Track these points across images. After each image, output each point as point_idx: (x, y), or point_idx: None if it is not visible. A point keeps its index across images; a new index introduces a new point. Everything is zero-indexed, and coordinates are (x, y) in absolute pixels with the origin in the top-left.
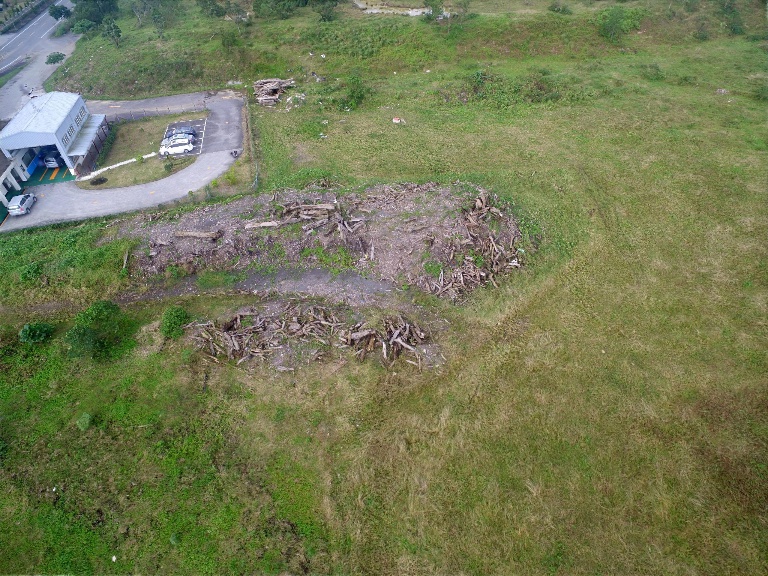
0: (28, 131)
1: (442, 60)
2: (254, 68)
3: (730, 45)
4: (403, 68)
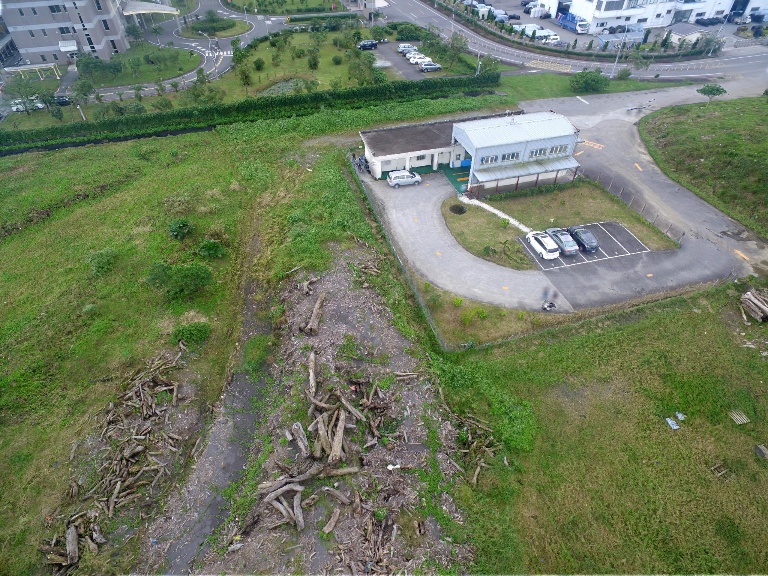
0: (467, 133)
1: None
2: None
3: None
4: None
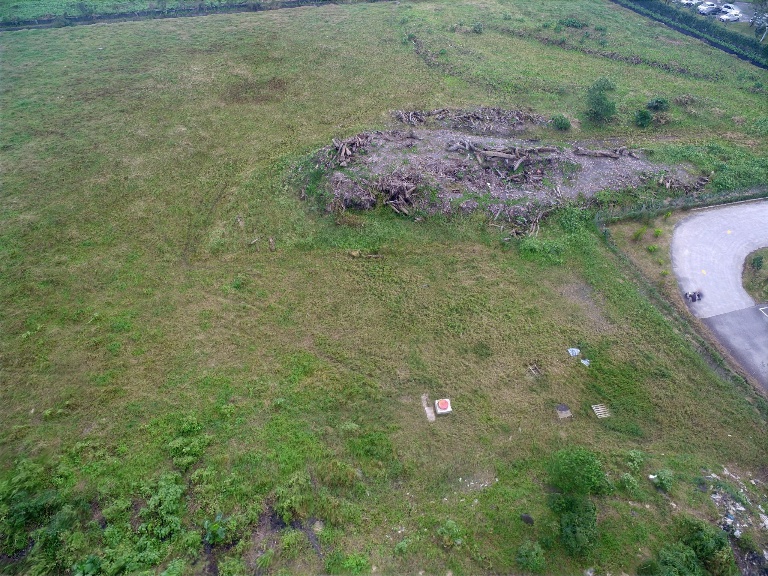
0: None
1: None
2: None
3: None
4: None
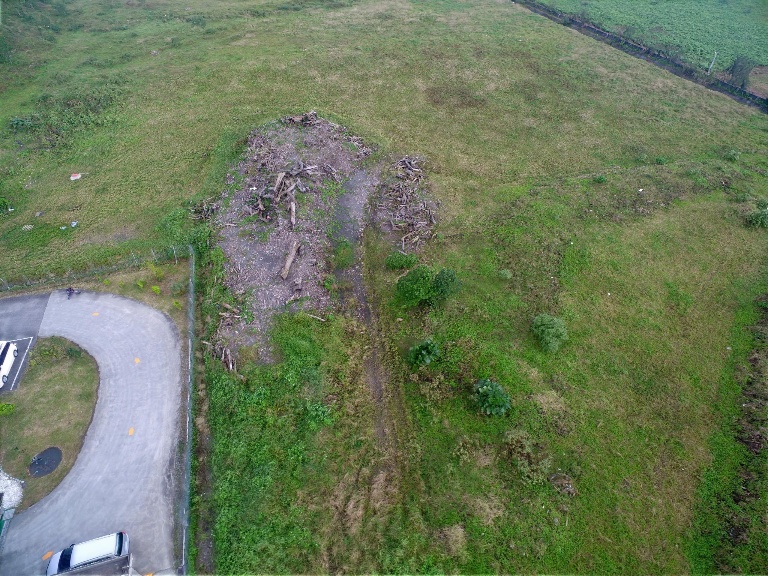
0: None
1: None
2: None
3: (75, 37)
4: None
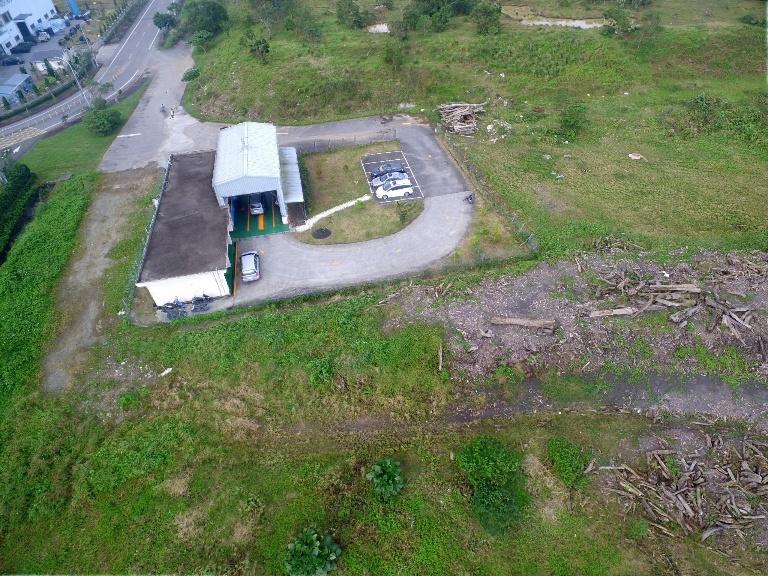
0: (252, 175)
1: (639, 80)
2: (427, 89)
3: None
4: (597, 90)
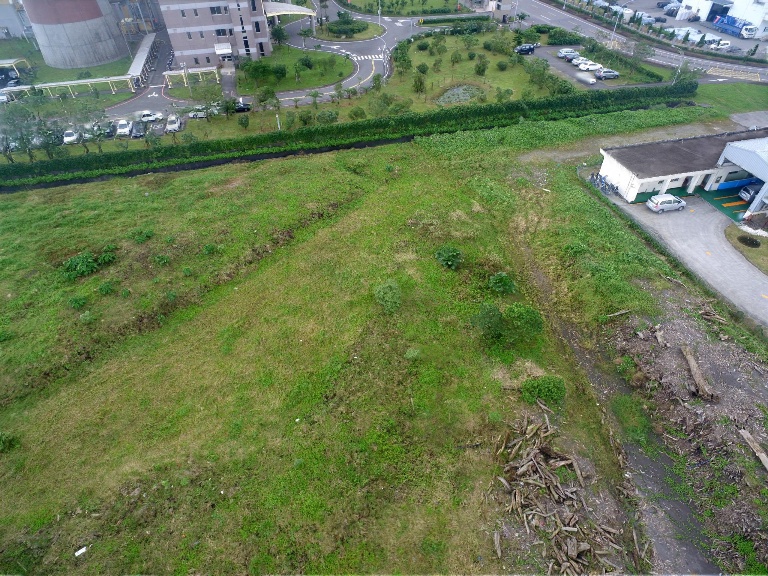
0: (760, 155)
1: None
2: None
3: None
4: None
